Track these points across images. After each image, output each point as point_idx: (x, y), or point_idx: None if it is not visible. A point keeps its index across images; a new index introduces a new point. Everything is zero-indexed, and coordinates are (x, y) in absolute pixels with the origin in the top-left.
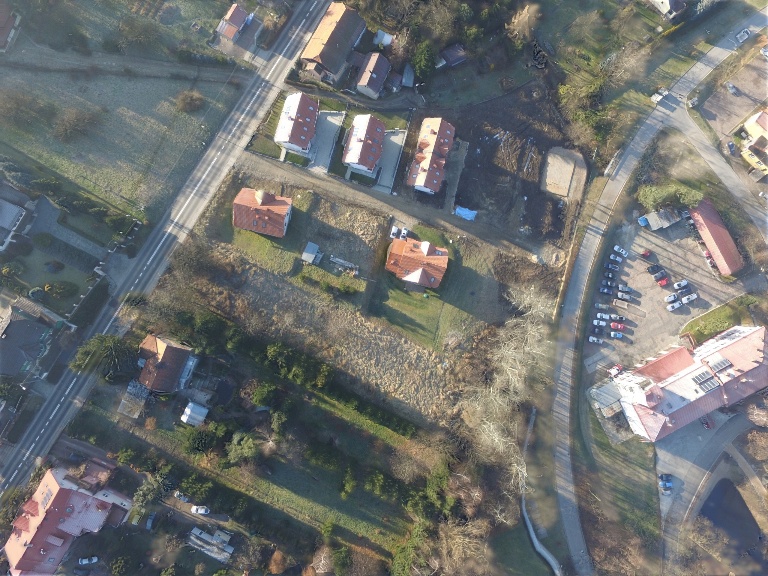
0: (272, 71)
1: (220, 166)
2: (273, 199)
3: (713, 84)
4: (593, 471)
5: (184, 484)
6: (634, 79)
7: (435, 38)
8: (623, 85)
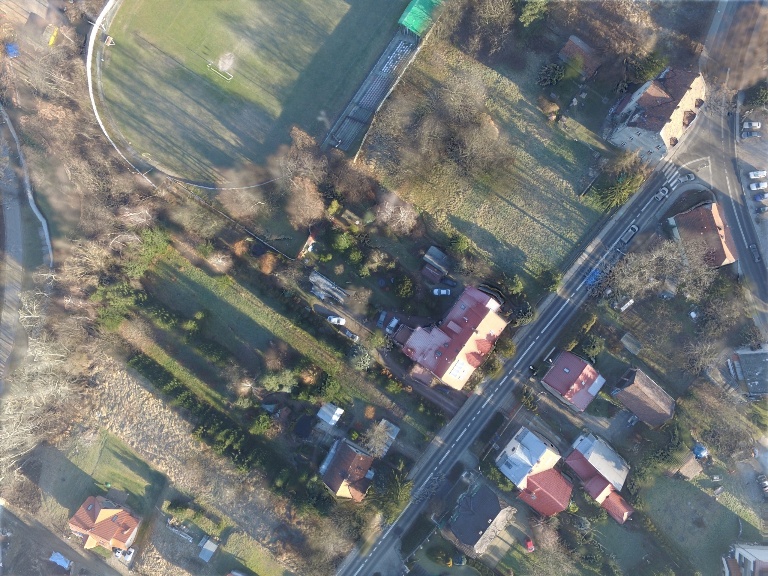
0: None
1: None
2: None
3: None
4: None
5: None
6: None
7: None
8: None
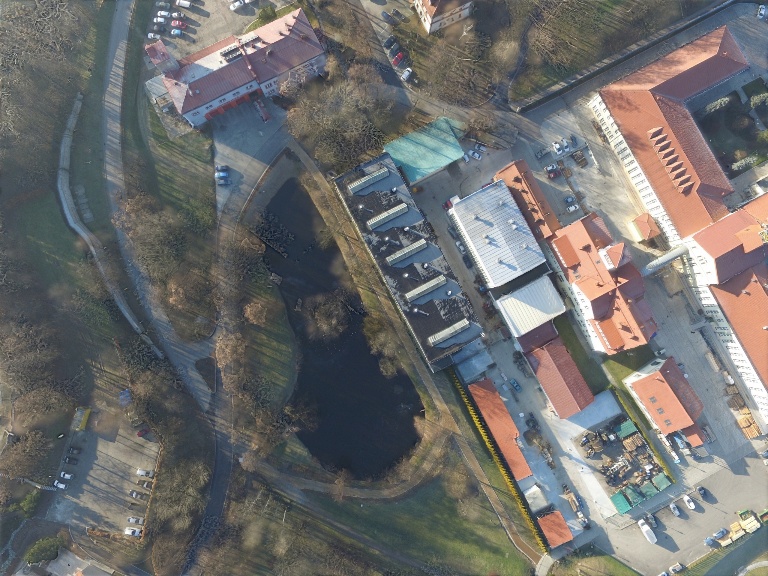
0: None
1: None
2: None
3: None
4: (147, 161)
5: None
6: None
7: None
8: None
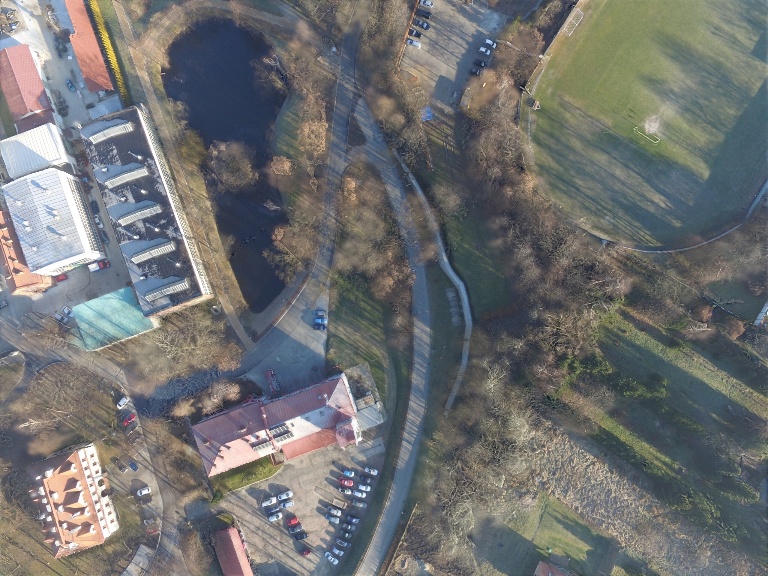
0: None
1: None
2: None
3: None
4: (391, 343)
5: None
6: None
7: None
8: None
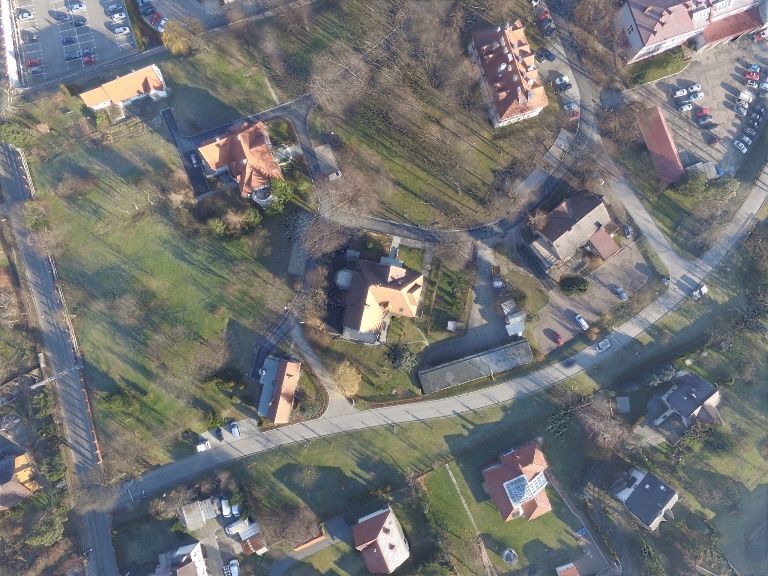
0: None
1: None
2: None
3: (639, 299)
4: None
5: None
6: (717, 314)
7: None
8: (728, 309)
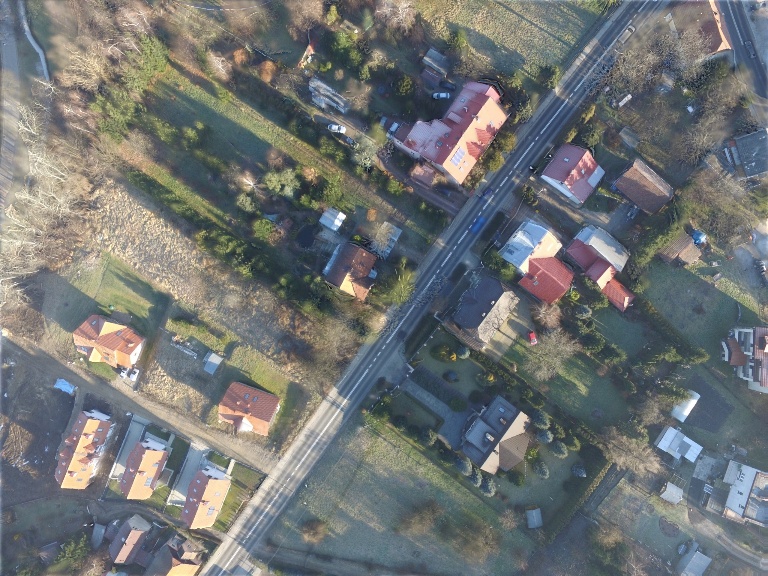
0: (234, 555)
1: (293, 461)
2: (235, 422)
3: None
4: None
5: (340, 155)
6: None
7: (59, 573)
8: None
